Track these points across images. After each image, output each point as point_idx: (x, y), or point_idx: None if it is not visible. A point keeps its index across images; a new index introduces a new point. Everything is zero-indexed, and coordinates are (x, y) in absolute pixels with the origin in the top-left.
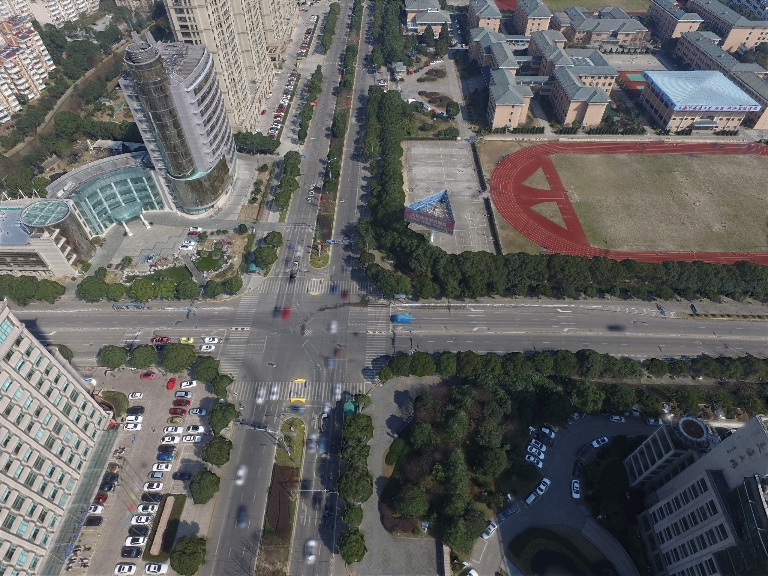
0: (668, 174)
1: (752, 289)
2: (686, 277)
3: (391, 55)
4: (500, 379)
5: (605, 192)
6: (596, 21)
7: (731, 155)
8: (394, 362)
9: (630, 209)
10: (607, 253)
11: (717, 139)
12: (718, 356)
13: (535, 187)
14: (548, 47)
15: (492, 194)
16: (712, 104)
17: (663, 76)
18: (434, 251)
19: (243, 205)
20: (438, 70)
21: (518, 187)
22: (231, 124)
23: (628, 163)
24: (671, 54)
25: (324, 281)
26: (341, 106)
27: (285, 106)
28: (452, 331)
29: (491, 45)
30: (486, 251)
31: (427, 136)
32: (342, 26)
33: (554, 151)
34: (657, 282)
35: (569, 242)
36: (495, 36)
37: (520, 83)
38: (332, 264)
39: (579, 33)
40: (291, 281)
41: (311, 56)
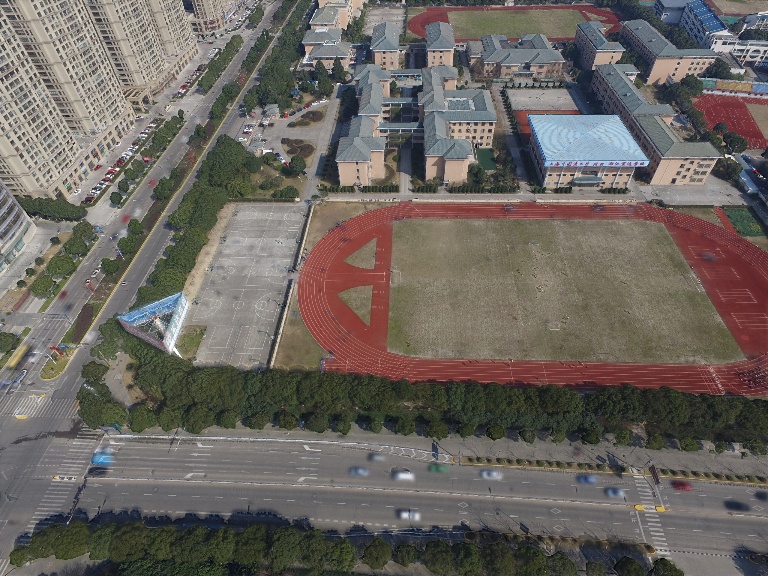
0: (523, 247)
1: (556, 424)
2: (471, 407)
3: (265, 96)
4: (155, 572)
5: (437, 272)
6: (507, 52)
7: (610, 220)
8: (32, 540)
9: (457, 297)
10: (403, 361)
11: (600, 199)
12: (481, 528)
13: (357, 265)
14: (425, 88)
15: (301, 275)
16: (589, 159)
17: (547, 122)
18: (165, 367)
19: (9, 289)
20: (316, 112)
21: (336, 265)
22: (34, 188)
23: (481, 232)
24: (588, 88)
25: (43, 399)
26: (187, 158)
27: (126, 159)
28: (157, 479)
29: (363, 86)
30: (253, 358)
31: (264, 196)
32: (240, 60)
33: (401, 216)
34: (439, 410)
35: (363, 344)
36: (378, 74)
37: (387, 131)
38: (66, 374)
39: (488, 65)
40: (5, 398)
41: (188, 97)
